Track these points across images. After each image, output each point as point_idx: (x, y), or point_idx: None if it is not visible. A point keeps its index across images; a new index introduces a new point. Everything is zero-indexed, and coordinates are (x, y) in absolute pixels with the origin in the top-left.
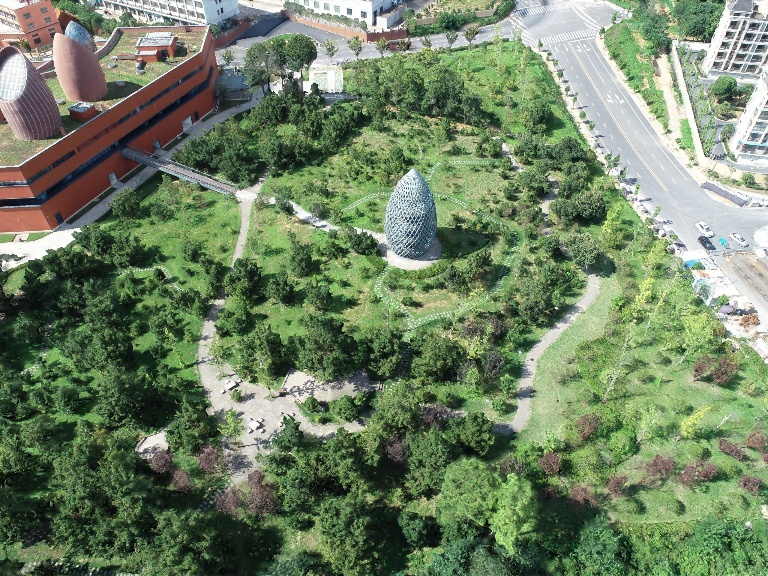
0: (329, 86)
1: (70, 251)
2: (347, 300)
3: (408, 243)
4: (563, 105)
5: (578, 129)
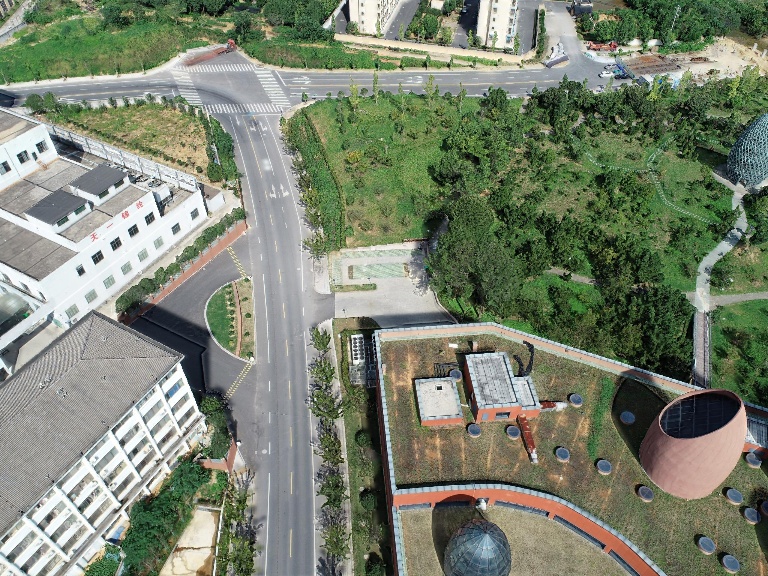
0: (393, 261)
1: None
2: None
3: None
4: None
5: None
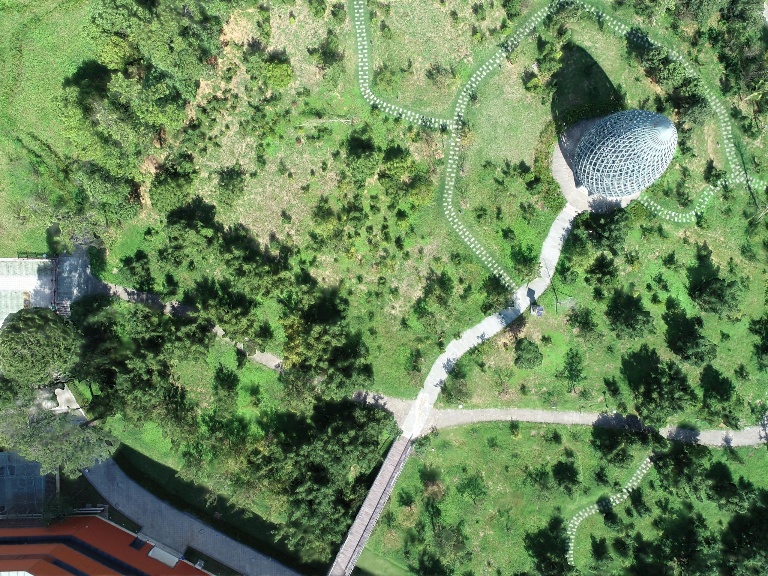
0: (7, 288)
1: None
2: None
3: None
4: None
5: None
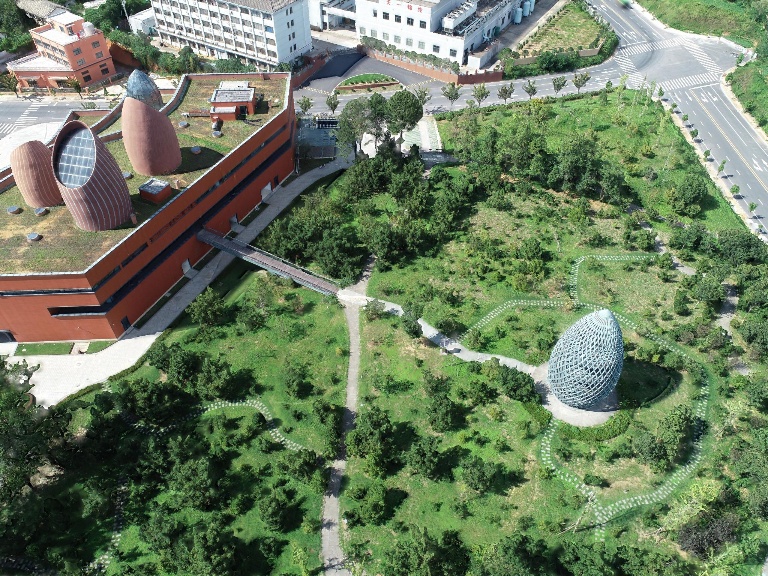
0: (423, 142)
1: (147, 384)
2: (512, 476)
3: (586, 396)
4: (709, 176)
5: (731, 207)
